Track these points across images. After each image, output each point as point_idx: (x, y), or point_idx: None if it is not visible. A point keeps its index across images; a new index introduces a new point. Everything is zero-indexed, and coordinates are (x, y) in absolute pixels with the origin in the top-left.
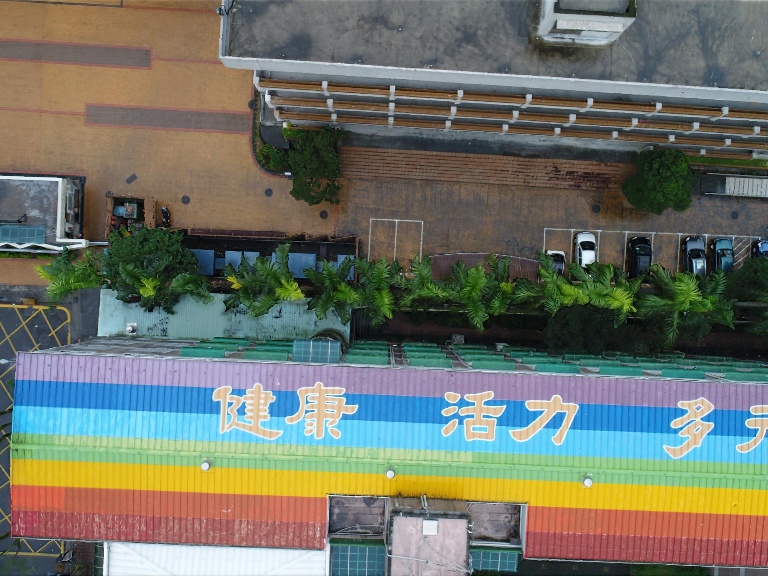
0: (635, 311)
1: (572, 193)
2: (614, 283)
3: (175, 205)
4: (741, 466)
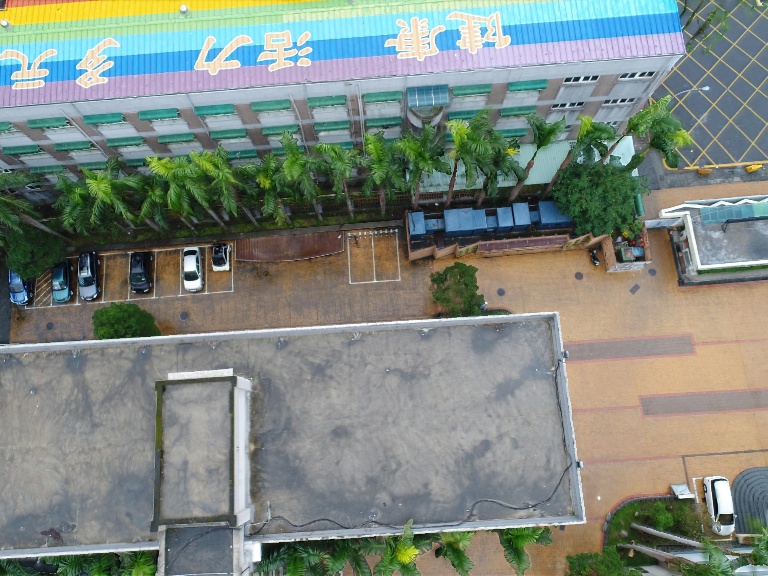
0: (147, 157)
1: (208, 328)
2: (165, 250)
3: (588, 270)
4: (53, 39)
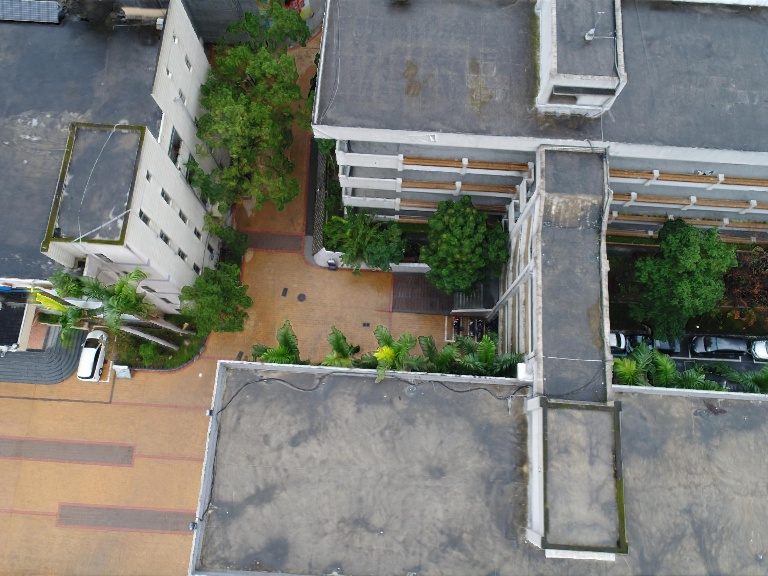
0: None
1: None
2: None
3: None
4: None
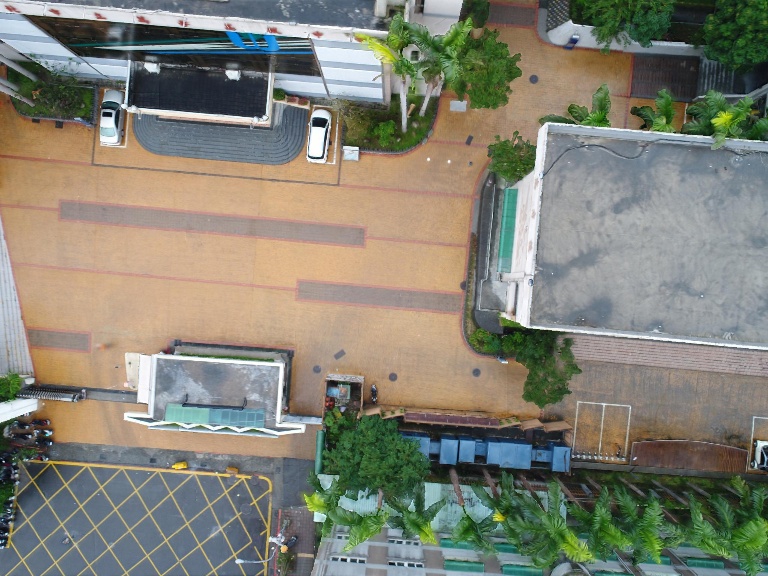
0: None
1: None
2: None
3: (382, 382)
4: None
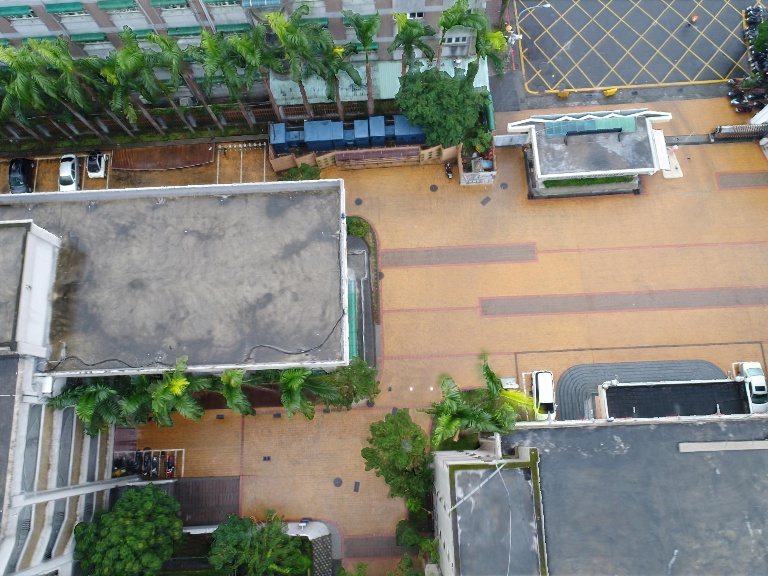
0: None
1: None
2: (46, 159)
3: (443, 183)
4: None
